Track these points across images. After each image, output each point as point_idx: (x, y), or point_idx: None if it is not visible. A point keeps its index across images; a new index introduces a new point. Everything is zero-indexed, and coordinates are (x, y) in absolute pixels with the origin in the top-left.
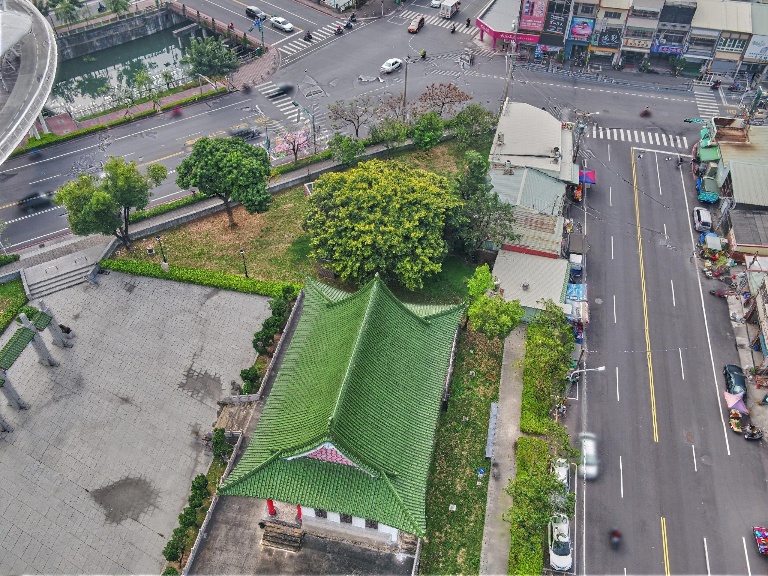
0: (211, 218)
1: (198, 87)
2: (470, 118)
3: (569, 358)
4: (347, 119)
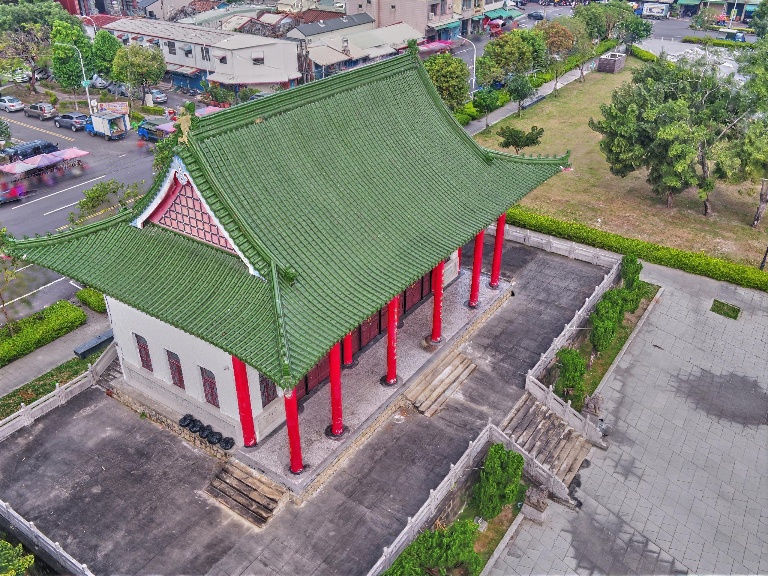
0: None
1: None
2: None
3: None
4: None
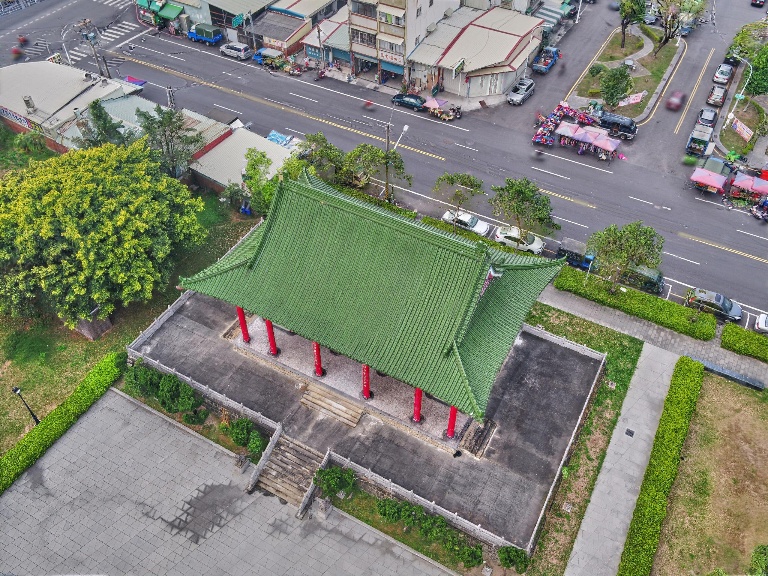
0: None
1: None
2: None
3: None
4: None
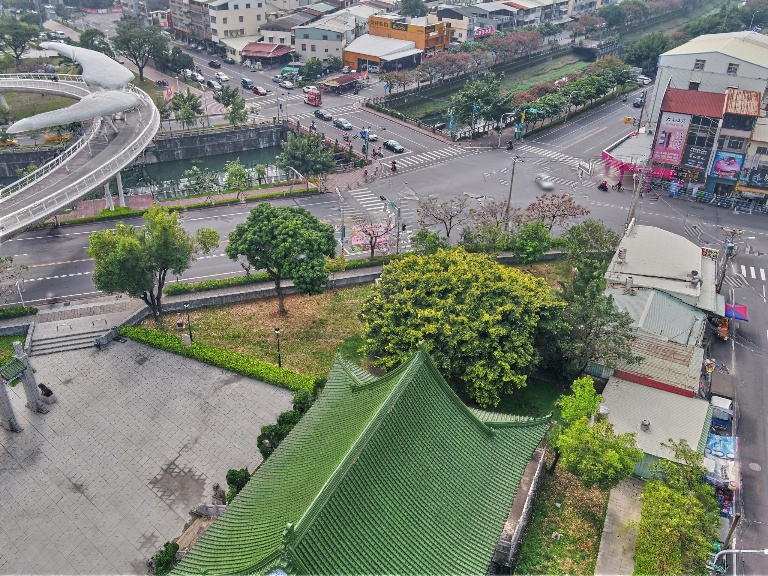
0: (260, 302)
1: (290, 186)
2: (585, 233)
3: (712, 528)
4: (438, 218)
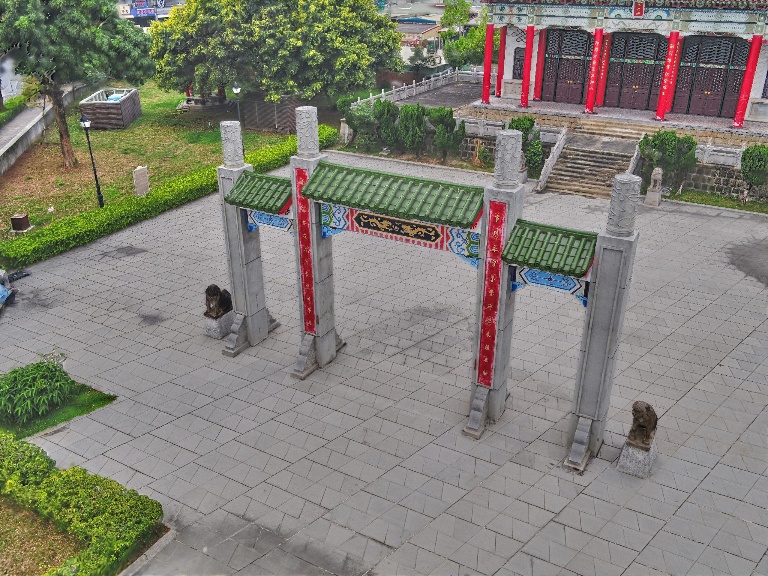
0: (14, 179)
1: None
2: None
3: None
4: None
